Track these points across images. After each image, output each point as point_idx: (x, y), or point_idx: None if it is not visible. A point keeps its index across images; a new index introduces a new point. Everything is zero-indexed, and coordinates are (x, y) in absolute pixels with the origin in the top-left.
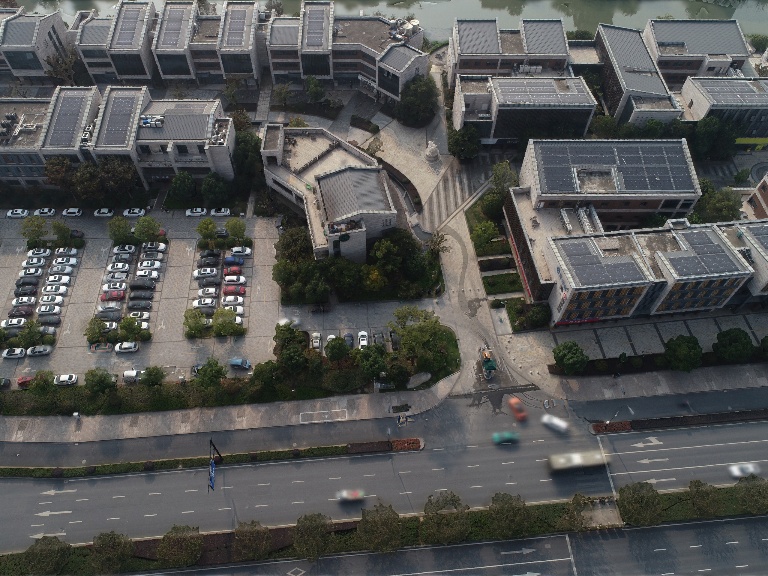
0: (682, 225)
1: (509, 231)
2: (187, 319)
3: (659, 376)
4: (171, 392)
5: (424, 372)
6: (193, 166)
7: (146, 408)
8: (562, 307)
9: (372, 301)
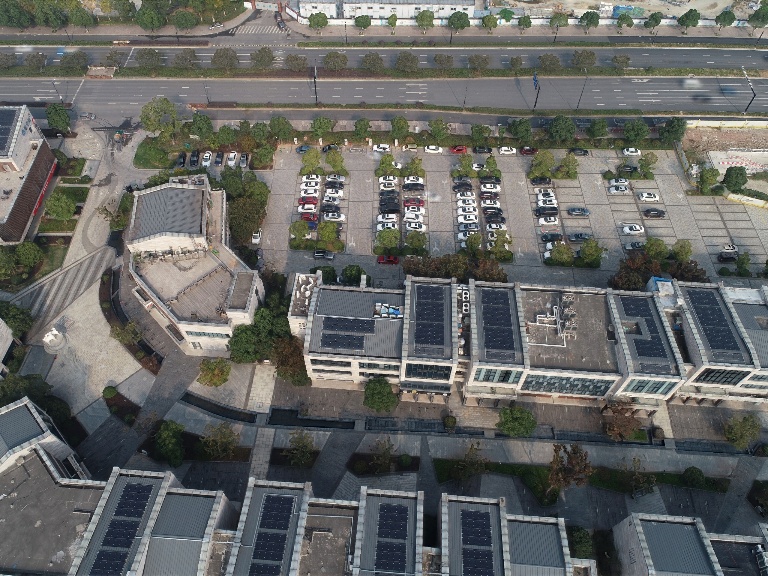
0: None
1: None
2: None
3: None
4: None
5: None
6: None
7: None
8: None
9: None
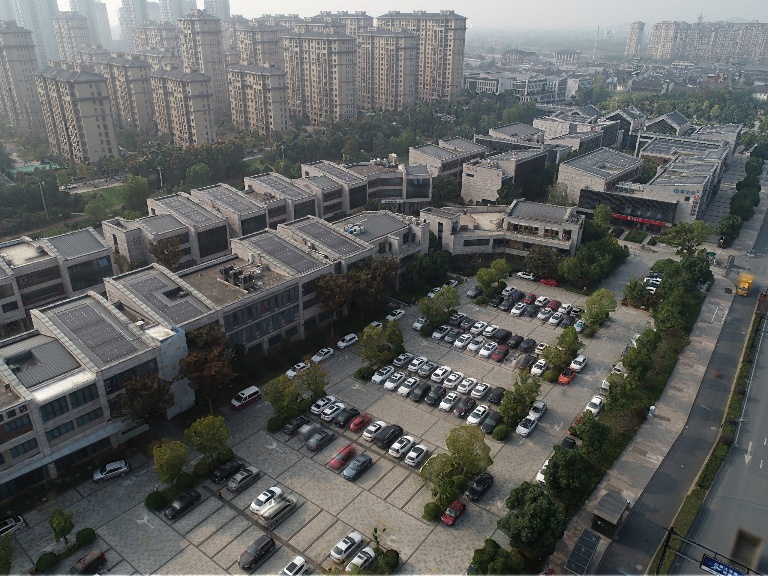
0: None
1: None
2: (596, 305)
3: (744, 230)
4: (655, 358)
5: None
6: (410, 253)
7: (666, 375)
8: (697, 208)
9: (614, 270)
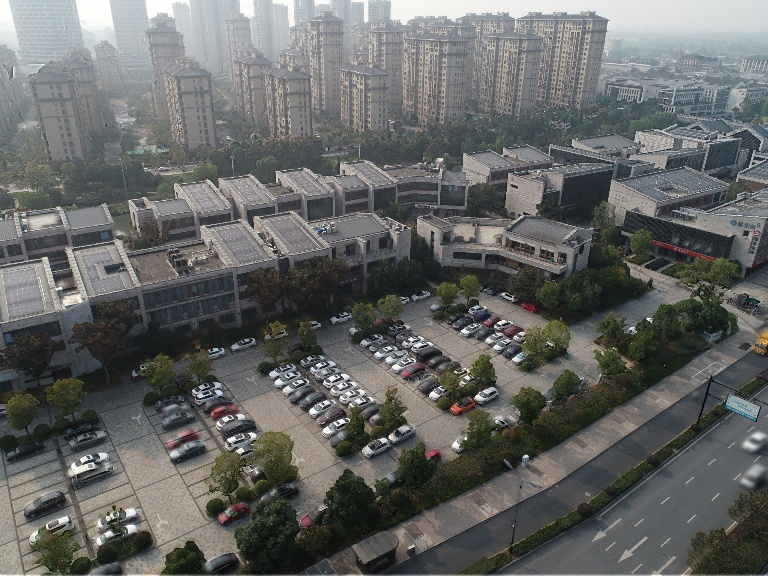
0: None
1: None
2: (534, 337)
3: None
4: (579, 406)
5: None
6: None
7: (576, 426)
8: (756, 245)
9: (619, 304)
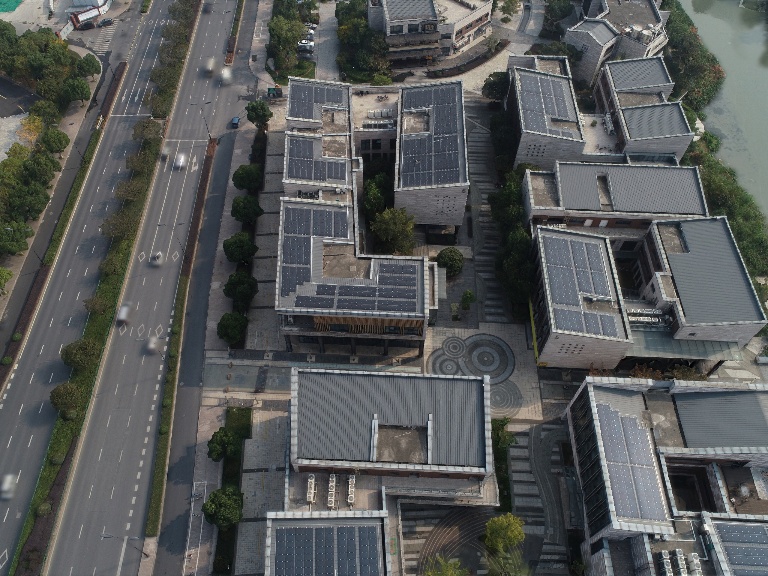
0: (357, 168)
1: None
2: None
3: None
4: None
5: None
6: None
7: None
8: None
9: None
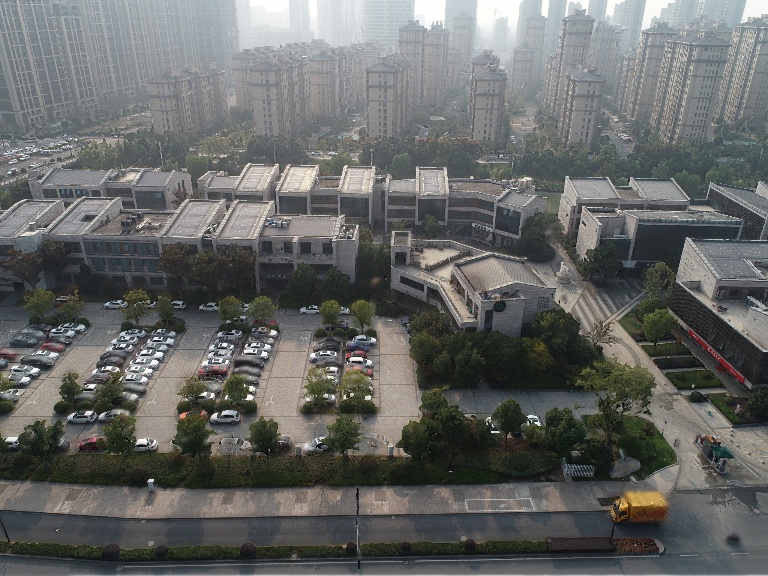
0: None
1: (684, 328)
2: (311, 378)
3: None
4: (282, 465)
5: (631, 457)
6: (315, 263)
7: (247, 481)
8: None
9: (533, 389)
